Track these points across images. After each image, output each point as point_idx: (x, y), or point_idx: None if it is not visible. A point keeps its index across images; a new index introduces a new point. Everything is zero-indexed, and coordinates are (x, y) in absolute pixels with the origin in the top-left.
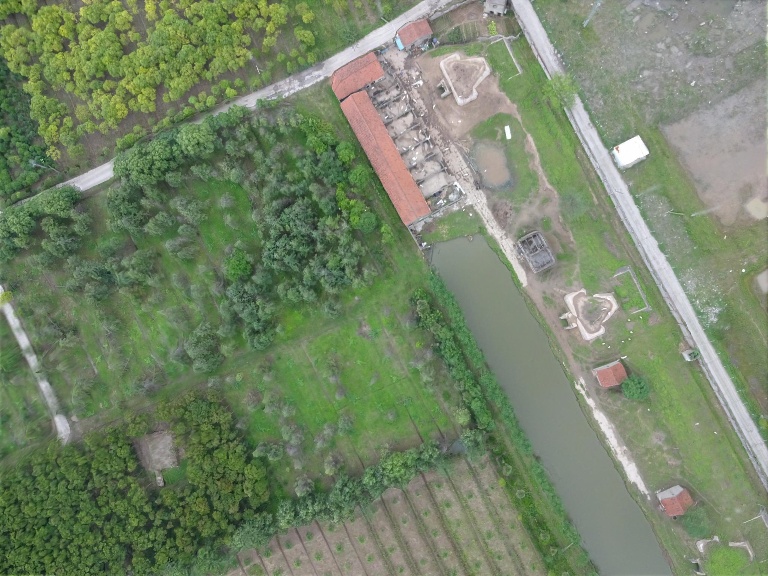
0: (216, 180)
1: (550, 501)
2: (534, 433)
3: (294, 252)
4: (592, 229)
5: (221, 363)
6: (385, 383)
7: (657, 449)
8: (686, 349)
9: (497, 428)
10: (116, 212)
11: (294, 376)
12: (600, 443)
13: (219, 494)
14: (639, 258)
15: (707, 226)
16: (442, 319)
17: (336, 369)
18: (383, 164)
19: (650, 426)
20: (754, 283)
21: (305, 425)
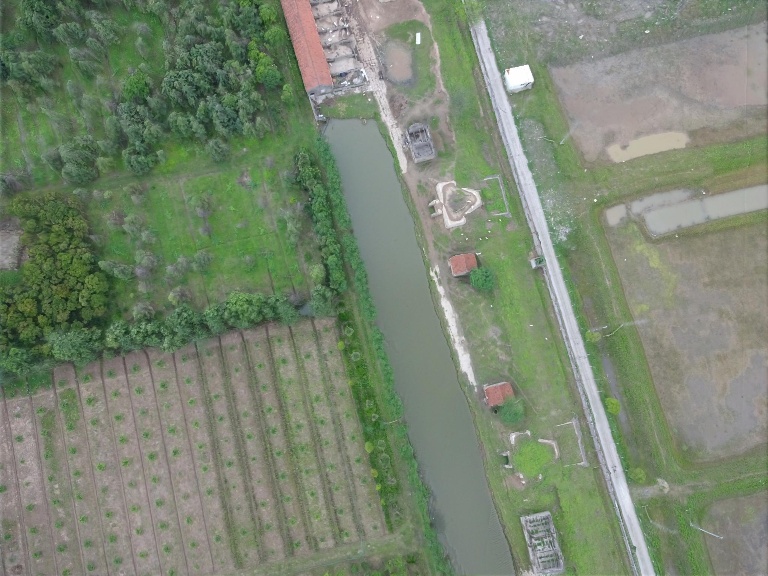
0: (138, 11)
1: (382, 369)
2: (382, 303)
3: (195, 87)
4: (474, 137)
5: (93, 180)
6: (252, 233)
7: (492, 343)
8: (534, 257)
9: (349, 297)
10: (29, 10)
11: (164, 208)
12: (442, 331)
13: (51, 299)
14: (509, 170)
15: (572, 156)
16: (320, 178)
17: (206, 204)
18: (299, 32)
19: (489, 319)
20: (603, 215)
21: (162, 257)
